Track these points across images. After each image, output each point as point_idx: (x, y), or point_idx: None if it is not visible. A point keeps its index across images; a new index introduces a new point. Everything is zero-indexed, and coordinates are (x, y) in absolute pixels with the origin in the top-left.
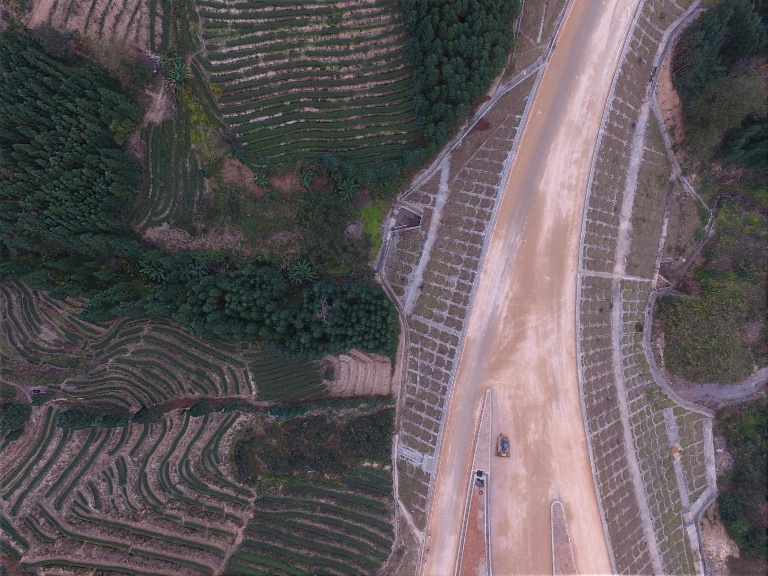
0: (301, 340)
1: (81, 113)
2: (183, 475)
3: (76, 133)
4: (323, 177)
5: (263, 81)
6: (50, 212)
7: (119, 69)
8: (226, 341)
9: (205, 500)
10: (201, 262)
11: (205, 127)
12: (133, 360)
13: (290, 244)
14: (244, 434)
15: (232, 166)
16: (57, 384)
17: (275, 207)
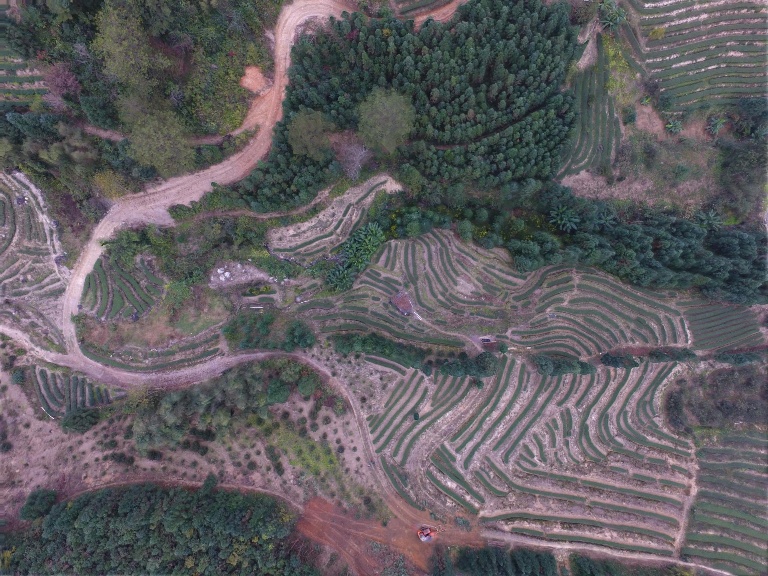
0: (760, 284)
1: (557, 51)
2: (621, 427)
3: (547, 72)
4: (726, 125)
5: (696, 24)
6: (503, 156)
7: (589, 7)
8: (653, 290)
9: (646, 452)
10: (613, 211)
11: (621, 73)
12: (573, 309)
13: (694, 193)
14: (682, 384)
15: (645, 113)
16: (502, 333)
17: (688, 155)
